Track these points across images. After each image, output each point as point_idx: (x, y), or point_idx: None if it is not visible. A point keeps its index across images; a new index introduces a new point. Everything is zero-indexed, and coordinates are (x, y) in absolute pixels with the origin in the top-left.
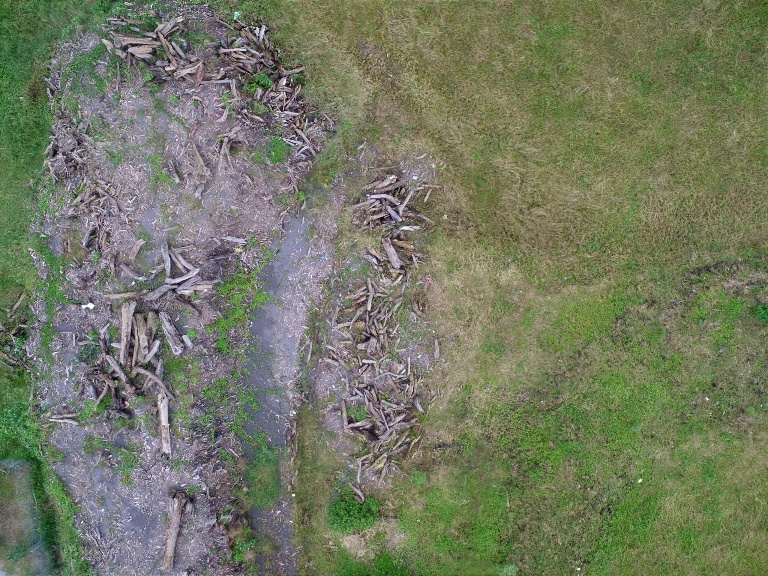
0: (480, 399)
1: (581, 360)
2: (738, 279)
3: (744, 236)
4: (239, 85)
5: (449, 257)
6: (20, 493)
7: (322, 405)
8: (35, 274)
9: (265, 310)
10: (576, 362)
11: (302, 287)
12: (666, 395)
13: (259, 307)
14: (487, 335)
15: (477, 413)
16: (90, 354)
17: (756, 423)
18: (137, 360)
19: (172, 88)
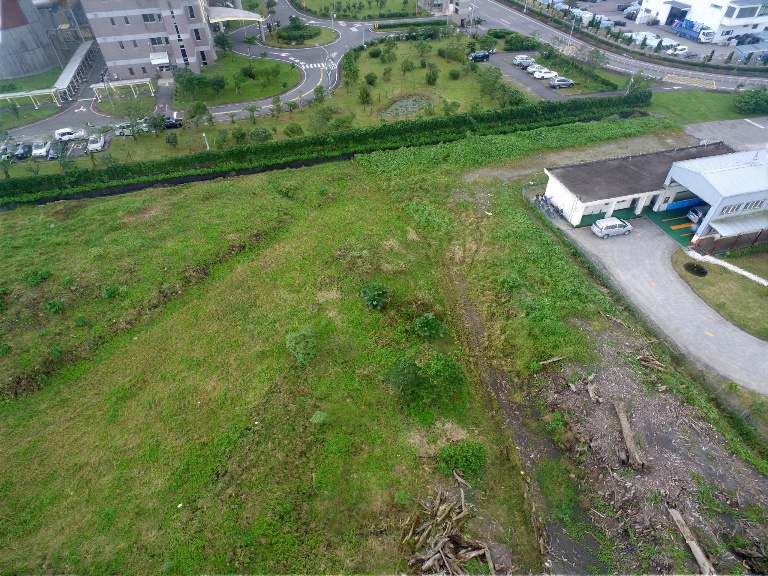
0: None
1: None
2: None
3: None
4: None
5: None
6: None
7: (518, 575)
8: None
9: None
10: None
11: None
12: None
13: None
14: None
15: (341, 575)
16: None
17: None
18: None
19: None
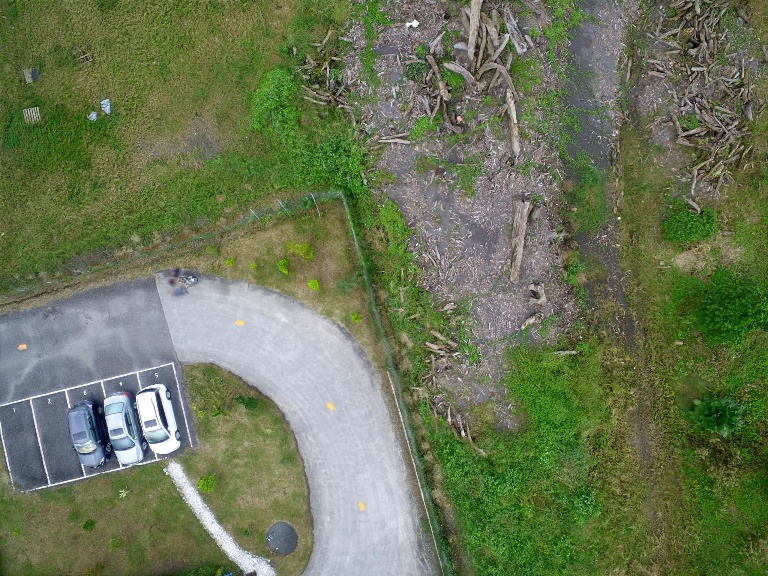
0: None
1: None
2: None
3: None
4: None
5: None
6: (334, 235)
7: (647, 121)
8: (348, 3)
9: (582, 29)
10: None
11: (619, 3)
12: None
13: (577, 25)
14: None
15: None
16: (415, 74)
17: None
18: (482, 60)
19: None
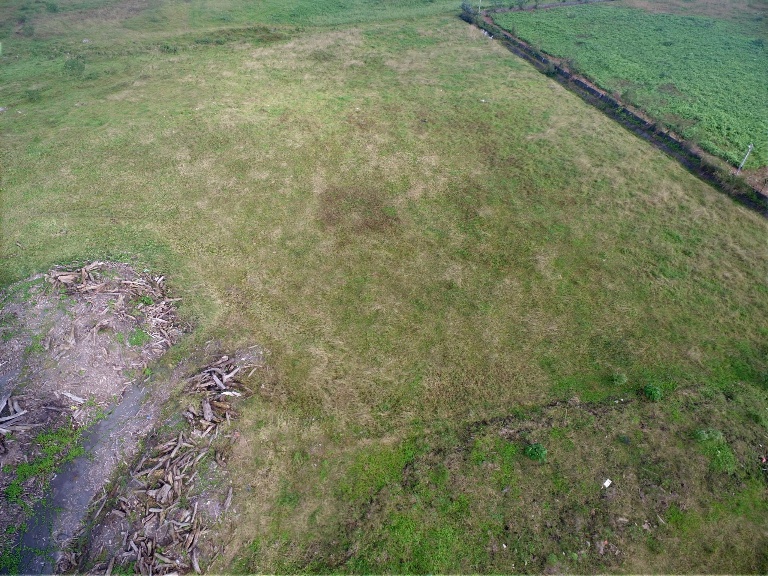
0: (266, 556)
1: (372, 506)
2: (509, 428)
3: (510, 397)
4: (128, 300)
5: (260, 416)
6: None
7: (89, 567)
8: None
9: (75, 464)
10: (367, 508)
11: (119, 443)
12: (458, 540)
13: (70, 461)
14: (284, 486)
15: (259, 572)
16: None
17: (564, 575)
18: None
19: (77, 298)
